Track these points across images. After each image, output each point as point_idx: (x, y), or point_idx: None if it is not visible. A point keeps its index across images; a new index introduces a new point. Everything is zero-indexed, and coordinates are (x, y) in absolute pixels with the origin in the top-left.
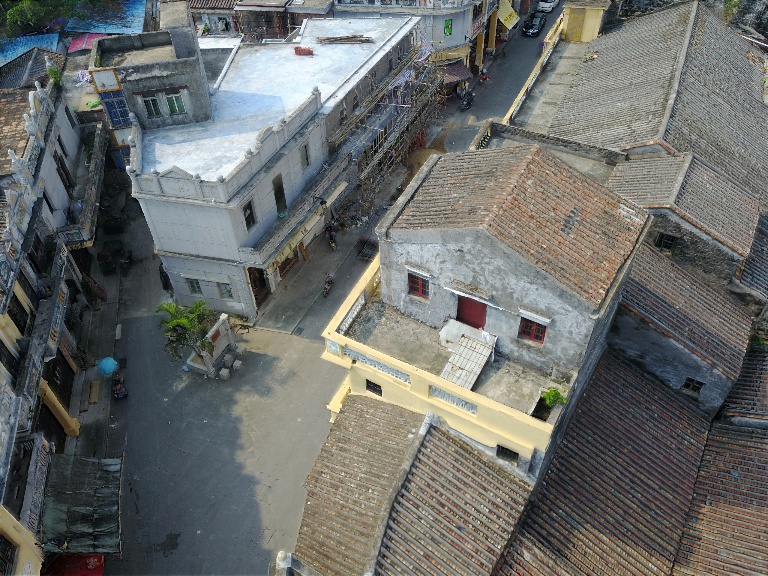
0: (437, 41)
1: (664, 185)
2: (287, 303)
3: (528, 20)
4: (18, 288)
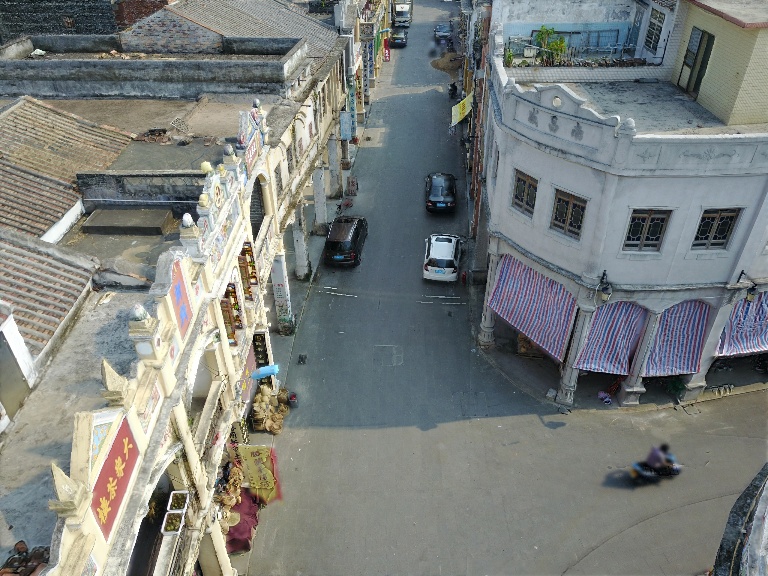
0: None
1: None
2: None
3: (452, 177)
4: None
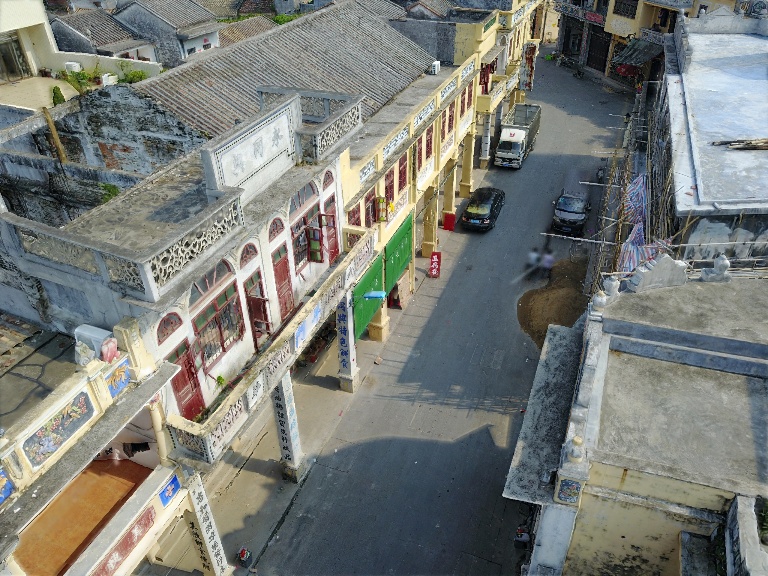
0: (627, 278)
1: (363, 0)
2: None
3: None
4: None
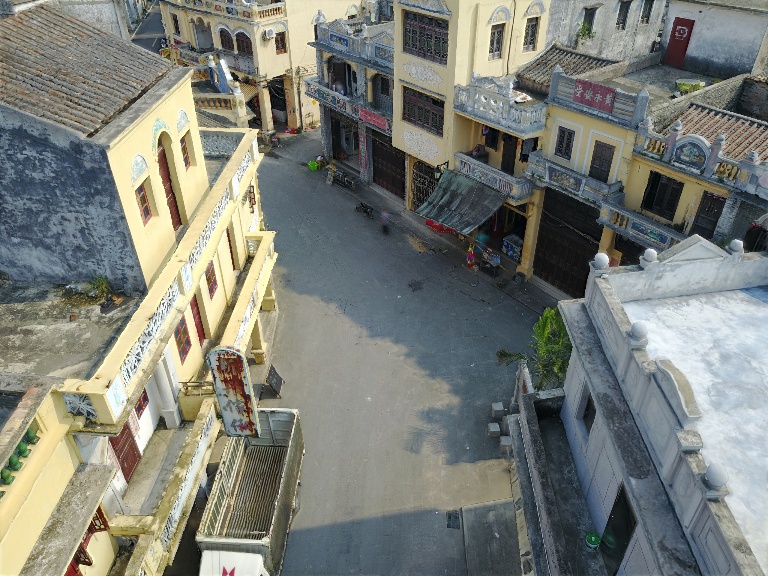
0: None
1: None
2: (515, 568)
3: None
4: (695, 197)
